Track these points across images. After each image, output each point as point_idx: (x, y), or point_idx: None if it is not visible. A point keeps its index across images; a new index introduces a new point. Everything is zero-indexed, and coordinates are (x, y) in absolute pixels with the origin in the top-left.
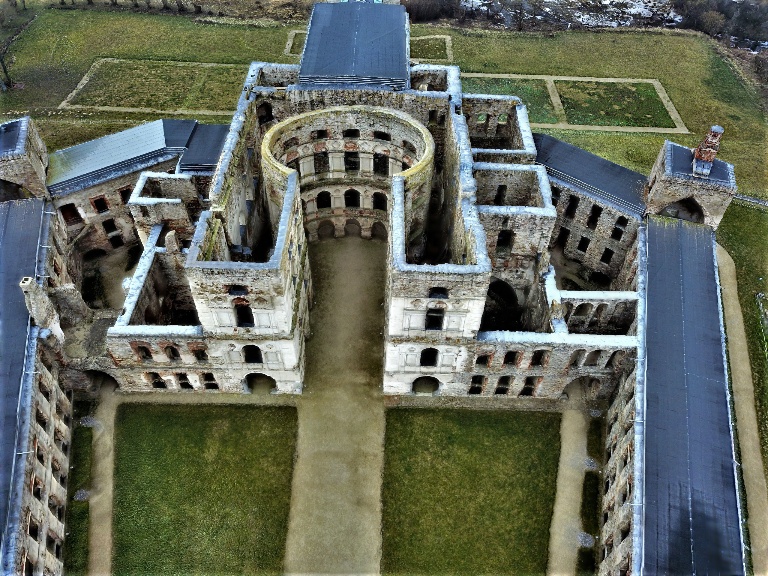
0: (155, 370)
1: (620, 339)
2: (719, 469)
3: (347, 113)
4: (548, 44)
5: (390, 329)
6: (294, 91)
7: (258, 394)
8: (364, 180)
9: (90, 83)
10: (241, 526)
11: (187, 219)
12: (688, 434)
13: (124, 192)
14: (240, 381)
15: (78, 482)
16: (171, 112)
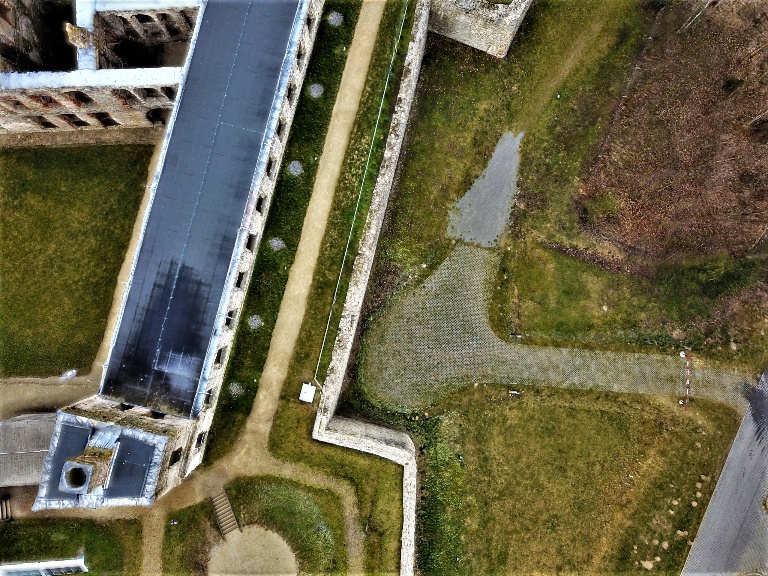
0: None
1: (159, 74)
2: (219, 241)
3: None
4: None
5: None
6: None
7: None
8: None
9: None
10: None
11: None
12: (197, 203)
13: None
14: None
15: None
16: None
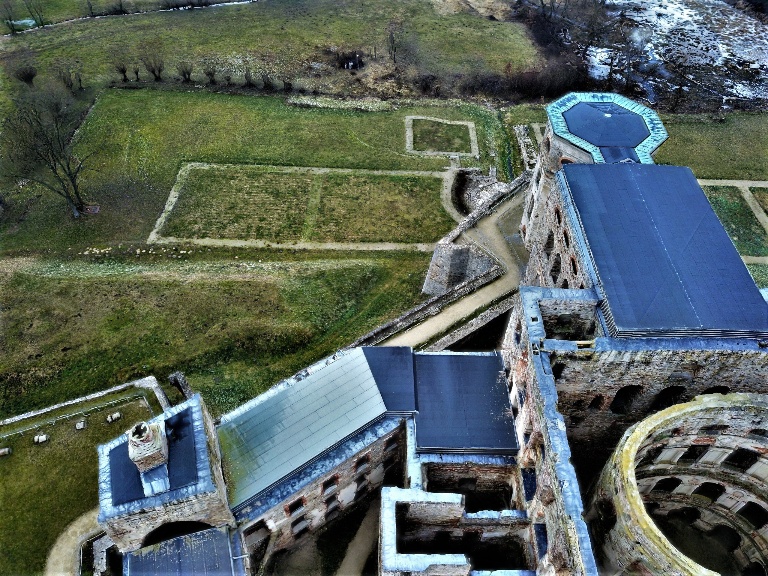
0: None
1: None
2: None
3: (723, 409)
4: (721, 133)
5: None
6: (610, 352)
7: None
8: (698, 471)
9: (180, 202)
10: None
11: (464, 575)
12: None
13: (327, 481)
14: None
15: None
16: (290, 246)
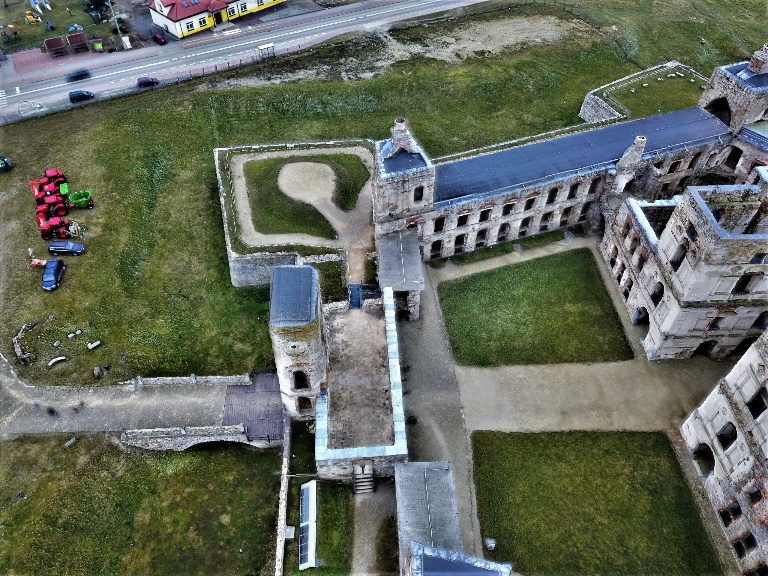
0: (619, 248)
1: None
2: None
3: None
4: None
5: (730, 373)
6: None
7: (635, 329)
8: None
9: None
10: (521, 335)
11: None
12: None
13: None
14: (637, 307)
15: (525, 243)
16: None
